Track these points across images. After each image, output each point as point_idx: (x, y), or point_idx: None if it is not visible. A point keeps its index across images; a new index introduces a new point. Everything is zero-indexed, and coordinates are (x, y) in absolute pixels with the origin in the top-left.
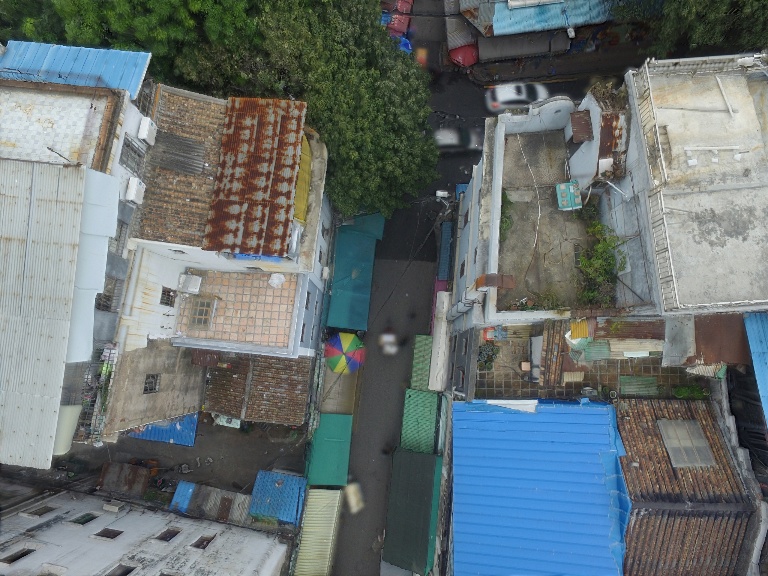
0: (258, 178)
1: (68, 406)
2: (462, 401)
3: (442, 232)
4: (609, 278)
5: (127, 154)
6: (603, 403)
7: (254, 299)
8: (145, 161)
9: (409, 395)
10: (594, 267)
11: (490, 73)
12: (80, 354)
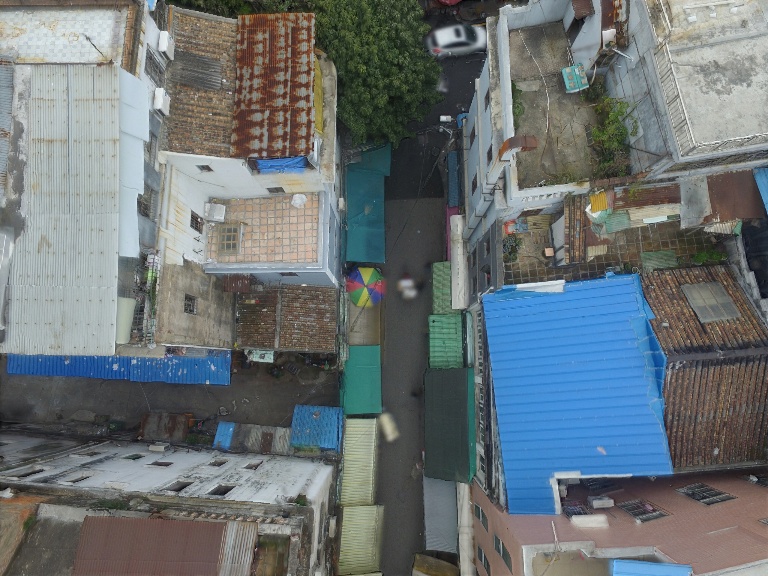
0: (276, 86)
1: (124, 298)
2: (491, 293)
3: (448, 161)
4: (622, 148)
5: (150, 66)
6: (628, 274)
7: (279, 221)
8: (166, 78)
9: (433, 320)
10: (608, 134)
11: (476, 12)
12: (129, 249)
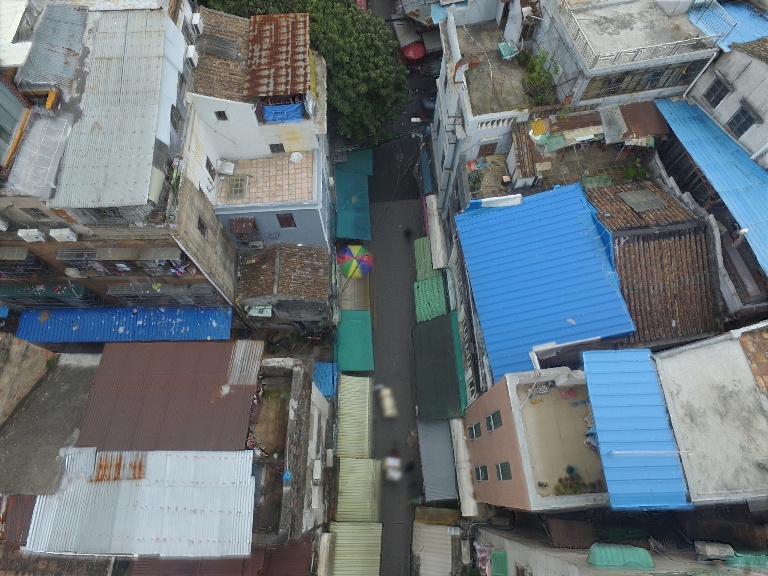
0: (280, 54)
1: (156, 169)
2: (462, 214)
3: (421, 160)
4: (550, 86)
5: (185, 32)
6: (571, 184)
7: (279, 173)
8: (195, 47)
9: (417, 286)
10: (536, 71)
11: (436, 67)
12: (163, 137)
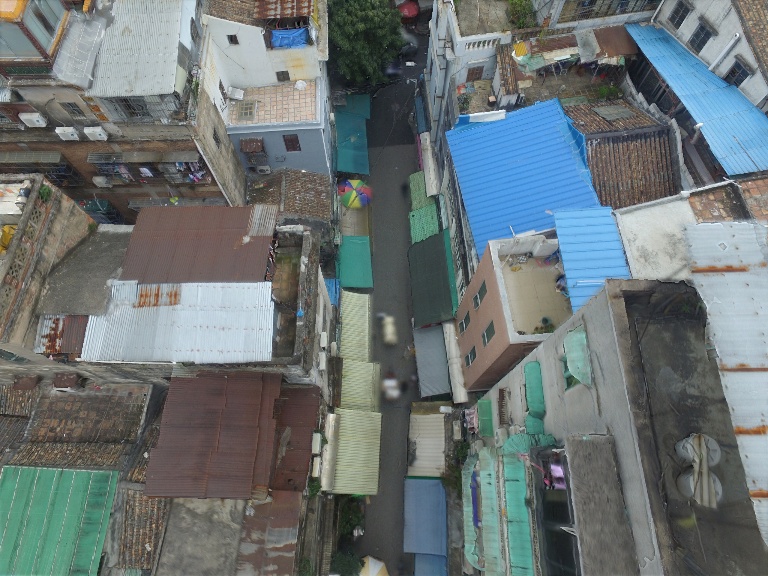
0: None
1: (180, 67)
2: (452, 130)
3: (415, 104)
4: (530, 12)
5: None
6: None
7: (285, 98)
8: None
9: (412, 215)
10: None
11: None
12: (185, 42)
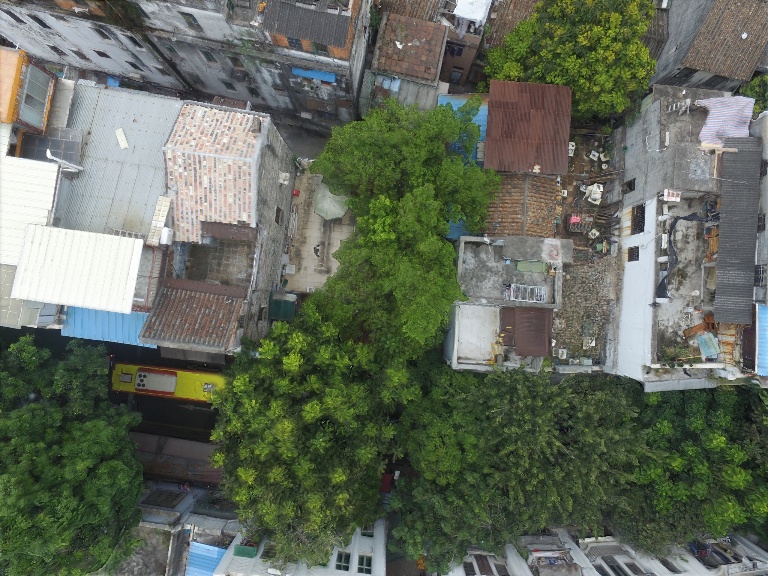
0: None
1: None
2: None
3: None
4: None
5: None
6: None
7: None
8: None
9: None
10: None
11: None
12: None
